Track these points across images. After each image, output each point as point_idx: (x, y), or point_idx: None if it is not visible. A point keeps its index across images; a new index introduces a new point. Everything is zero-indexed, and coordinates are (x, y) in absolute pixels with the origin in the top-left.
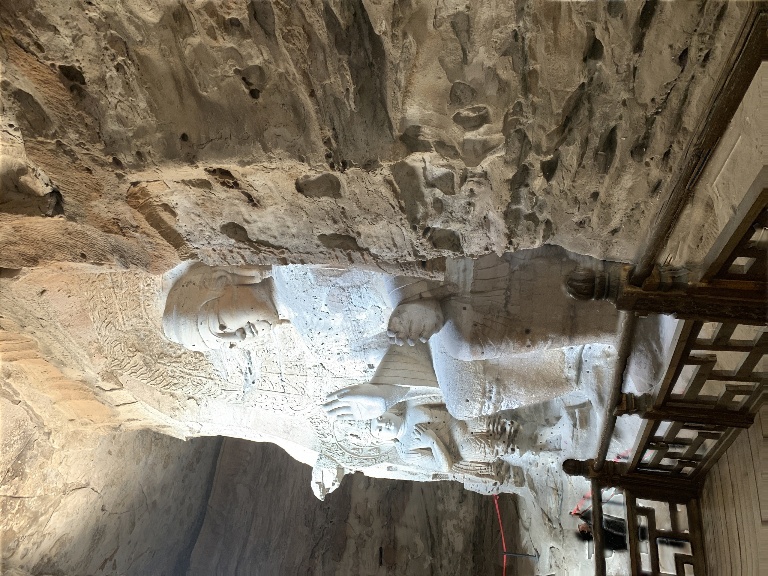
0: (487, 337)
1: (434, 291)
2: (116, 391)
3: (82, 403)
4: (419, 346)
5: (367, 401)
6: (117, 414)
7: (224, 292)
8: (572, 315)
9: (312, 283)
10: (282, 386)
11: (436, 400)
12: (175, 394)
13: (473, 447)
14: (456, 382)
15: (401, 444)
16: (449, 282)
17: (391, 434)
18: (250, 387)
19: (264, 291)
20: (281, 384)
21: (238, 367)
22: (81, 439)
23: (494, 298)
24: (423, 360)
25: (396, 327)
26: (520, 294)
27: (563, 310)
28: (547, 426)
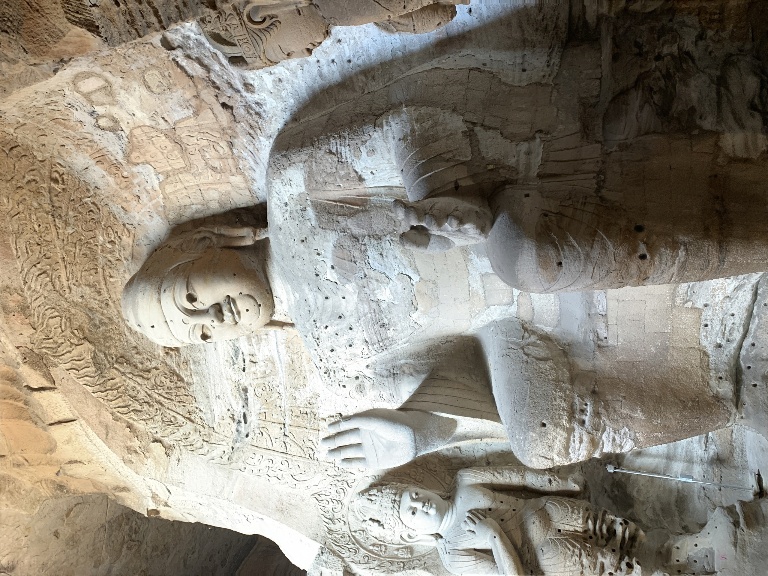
0: (566, 232)
1: (478, 176)
2: (46, 392)
3: (15, 427)
4: (473, 370)
5: (385, 429)
6: (54, 447)
7: (203, 254)
8: (719, 209)
9: (313, 225)
10: (284, 443)
11: (502, 478)
12: (135, 427)
13: (561, 552)
14: (525, 396)
15: (445, 540)
16: (502, 164)
17: (430, 522)
18: (242, 442)
19: (257, 259)
20: (283, 440)
21: (229, 410)
22: (11, 491)
23: (577, 182)
24: (478, 387)
25: (409, 203)
26: (622, 178)
27: (702, 201)
28: (686, 533)
